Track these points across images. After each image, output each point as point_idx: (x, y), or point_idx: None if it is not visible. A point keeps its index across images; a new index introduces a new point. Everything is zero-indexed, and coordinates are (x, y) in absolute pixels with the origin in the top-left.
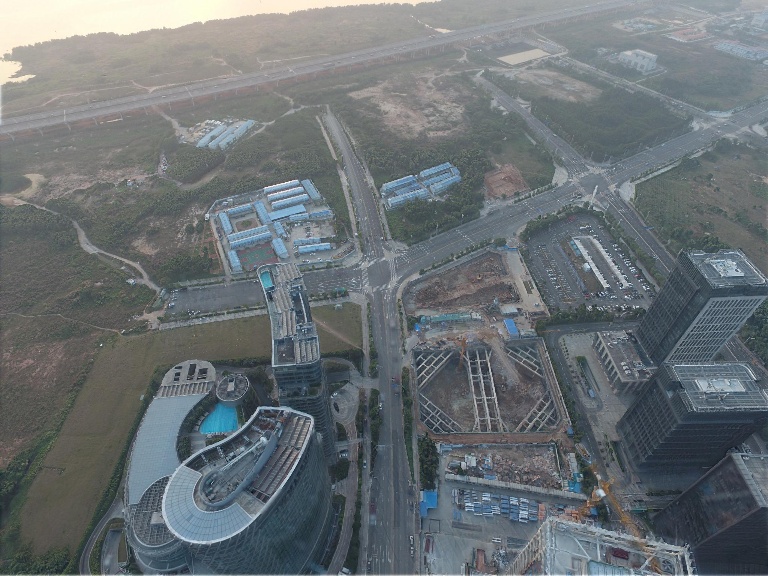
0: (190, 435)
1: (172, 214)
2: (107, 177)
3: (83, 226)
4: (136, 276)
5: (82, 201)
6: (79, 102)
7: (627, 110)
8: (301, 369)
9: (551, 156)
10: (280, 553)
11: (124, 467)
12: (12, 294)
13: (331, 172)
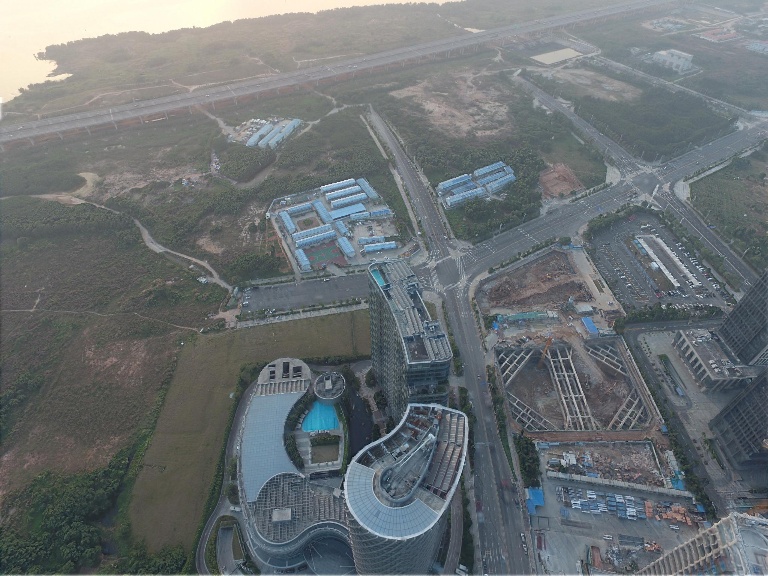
0: (293, 433)
1: (233, 213)
2: (161, 176)
3: (146, 225)
4: (206, 275)
5: (140, 200)
6: (122, 101)
7: (671, 109)
8: (435, 366)
9: (602, 155)
10: None
11: (224, 465)
12: (85, 292)
13: (384, 171)
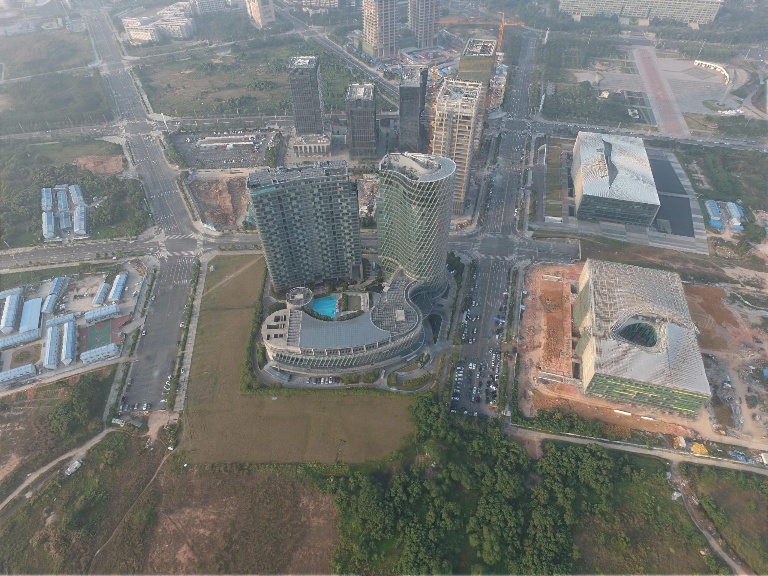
0: None
1: None
2: None
3: None
4: (62, 467)
5: None
6: None
7: (53, 90)
8: None
9: (87, 135)
10: None
11: None
12: None
13: None
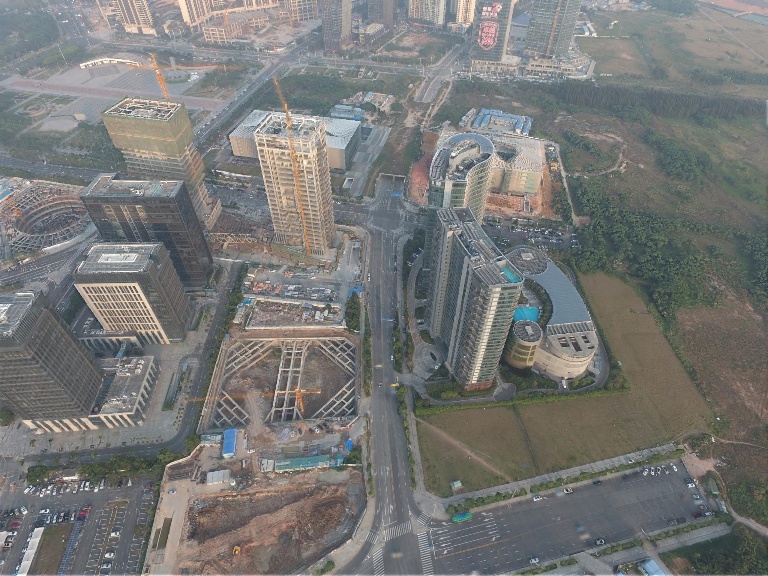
0: None
1: None
2: None
3: None
4: None
5: None
6: None
7: None
8: None
9: None
10: None
11: None
12: None
13: None
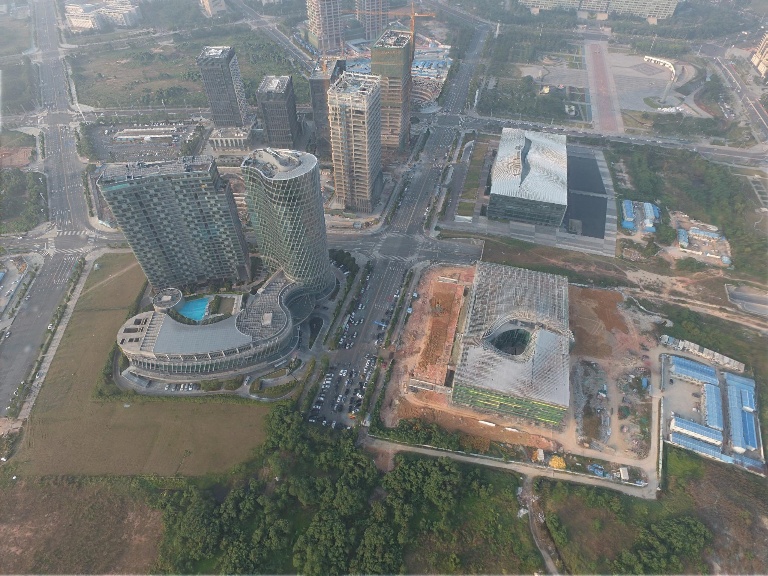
0: None
1: None
2: None
3: None
4: None
5: None
6: None
7: None
8: (214, 166)
9: None
10: None
11: None
12: None
13: None
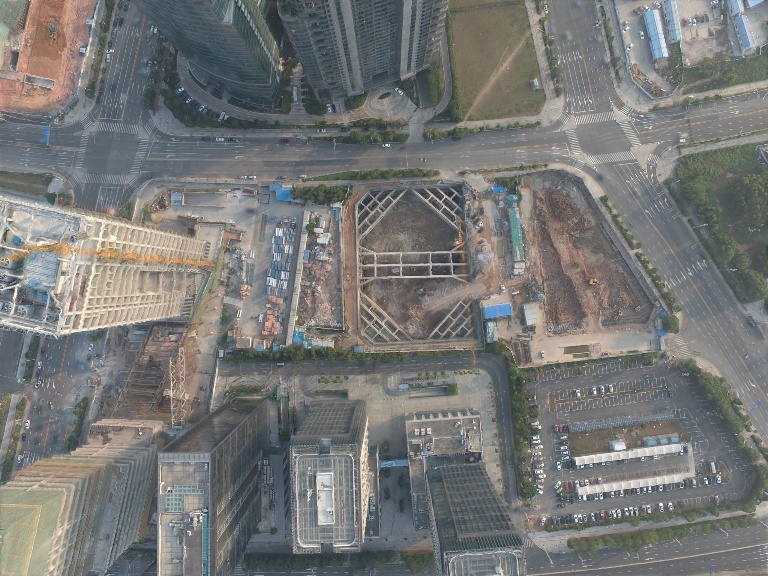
0: None
1: None
2: None
3: None
4: None
5: None
6: None
7: None
8: None
9: None
10: (151, 17)
11: None
12: None
13: None
